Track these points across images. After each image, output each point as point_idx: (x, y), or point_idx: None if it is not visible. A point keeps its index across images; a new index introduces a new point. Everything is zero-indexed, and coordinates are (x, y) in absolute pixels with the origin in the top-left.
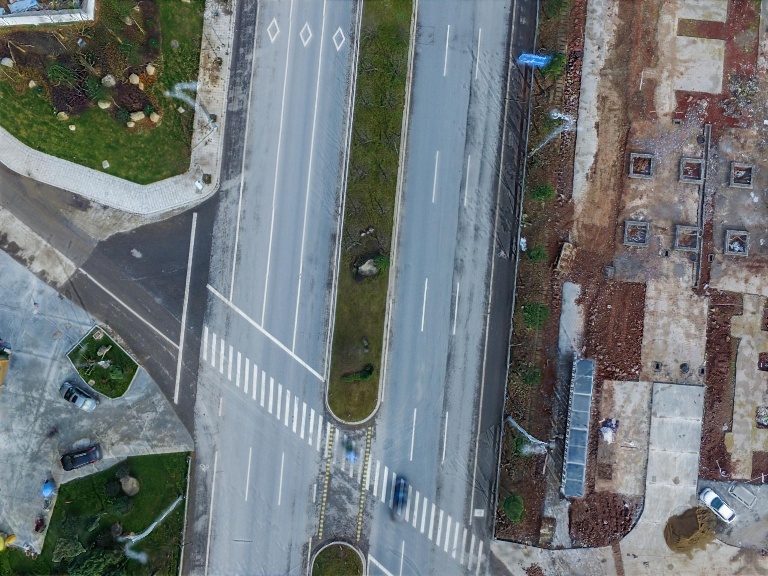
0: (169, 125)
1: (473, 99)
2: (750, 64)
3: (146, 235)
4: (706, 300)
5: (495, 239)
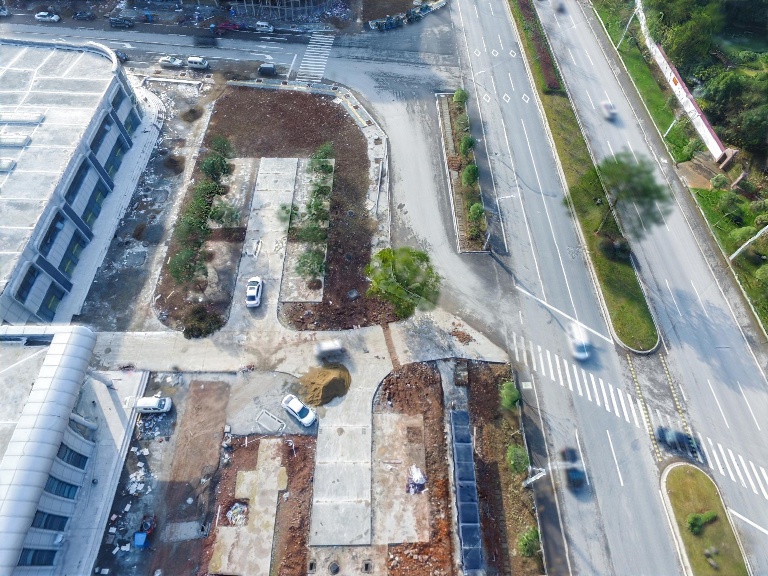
0: None
1: None
2: None
3: None
4: None
5: None
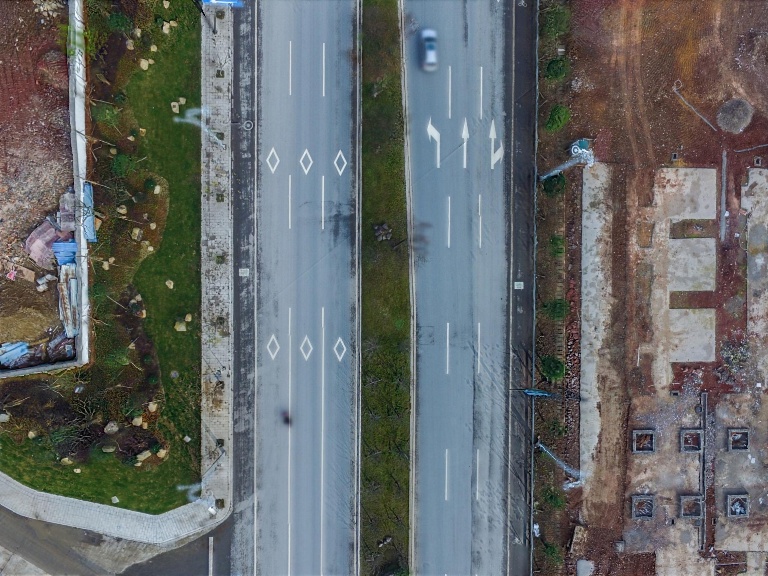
0: (177, 457)
1: (477, 394)
2: (740, 329)
3: (163, 564)
4: (712, 562)
5: (509, 528)
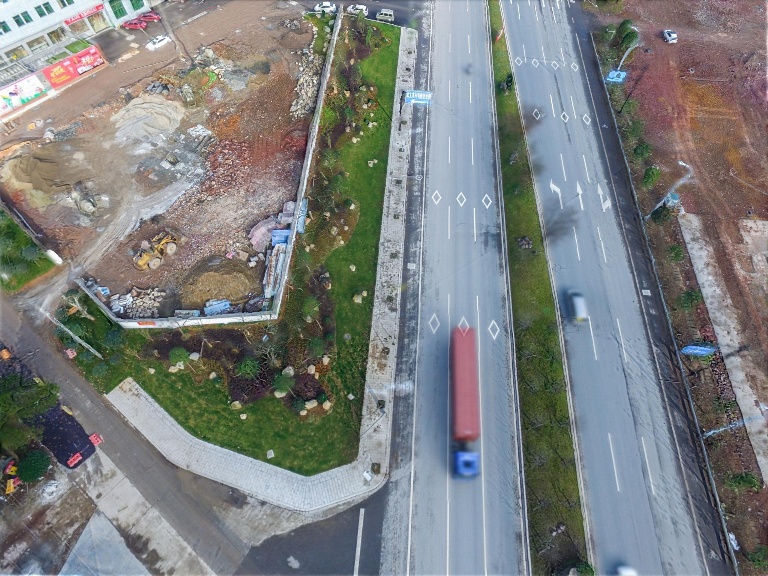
0: (340, 412)
1: (629, 381)
2: None
3: (306, 538)
4: None
5: (699, 535)
